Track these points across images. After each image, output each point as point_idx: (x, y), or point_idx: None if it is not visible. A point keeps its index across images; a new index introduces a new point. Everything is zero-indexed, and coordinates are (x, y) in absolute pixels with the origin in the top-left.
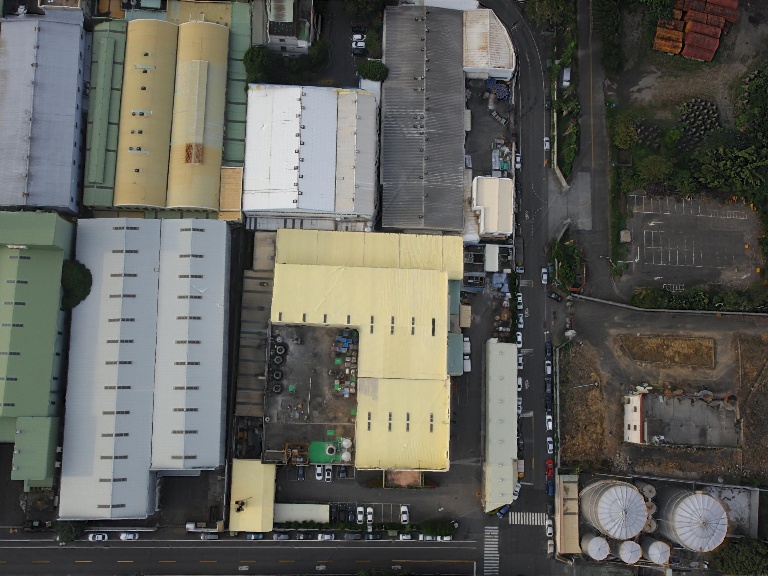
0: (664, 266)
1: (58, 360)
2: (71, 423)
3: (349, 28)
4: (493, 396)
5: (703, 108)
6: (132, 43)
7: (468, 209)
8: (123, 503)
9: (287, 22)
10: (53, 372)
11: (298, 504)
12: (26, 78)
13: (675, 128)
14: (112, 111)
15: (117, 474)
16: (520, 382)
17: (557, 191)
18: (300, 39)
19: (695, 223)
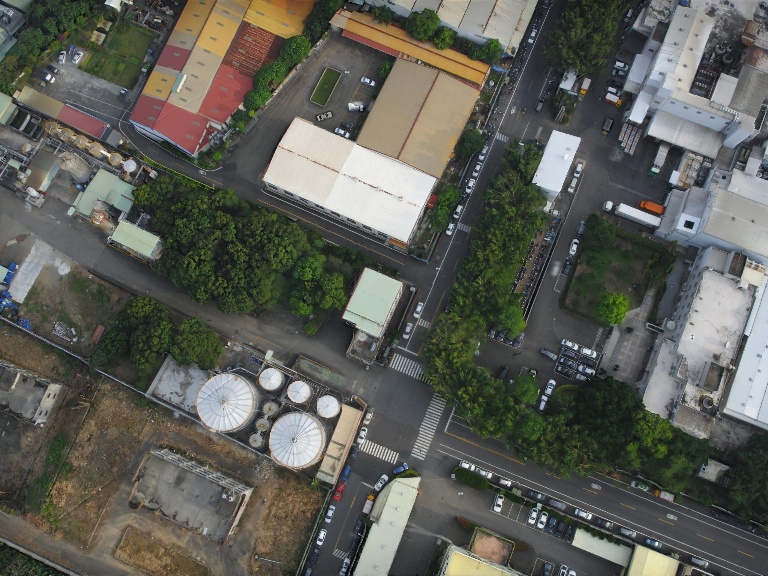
0: None
1: None
2: None
3: None
4: None
5: None
6: None
7: None
8: None
9: None
10: None
11: None
12: None
13: None
14: None
15: None
16: None
17: None
18: None
19: None
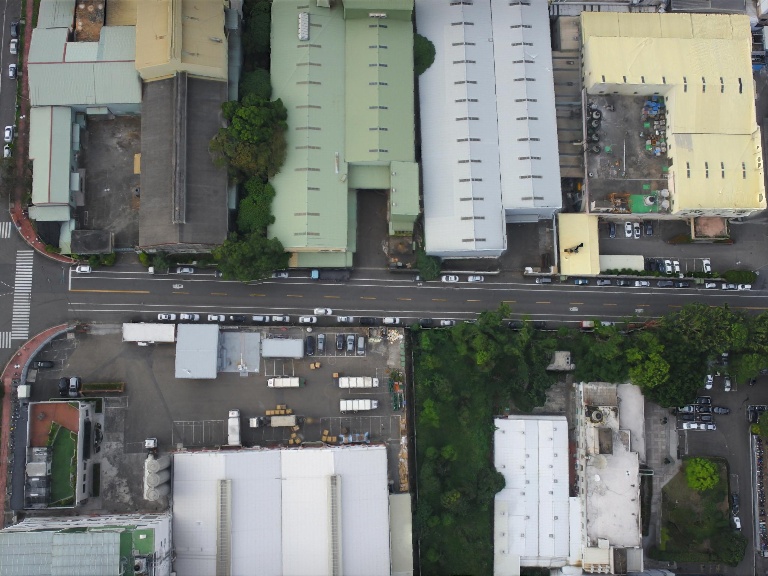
0: None
1: None
2: (429, 173)
3: None
4: None
5: None
6: None
7: None
8: (484, 238)
9: None
10: (414, 125)
11: (615, 255)
12: None
13: None
14: None
15: (476, 213)
16: None
17: None
18: None
19: None
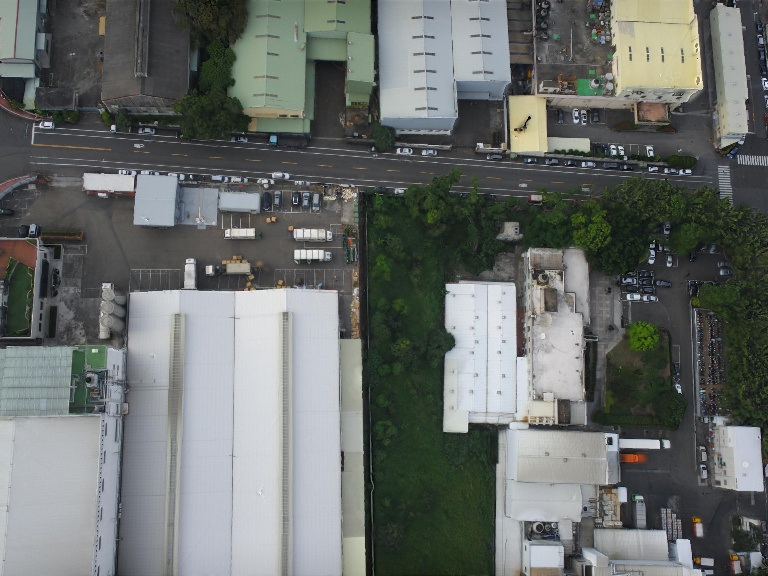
0: None
1: None
2: (384, 48)
3: None
4: (724, 48)
5: None
6: None
7: None
8: (436, 107)
9: None
10: None
11: (563, 138)
12: None
13: None
14: None
15: (429, 84)
16: None
17: None
18: None
19: None
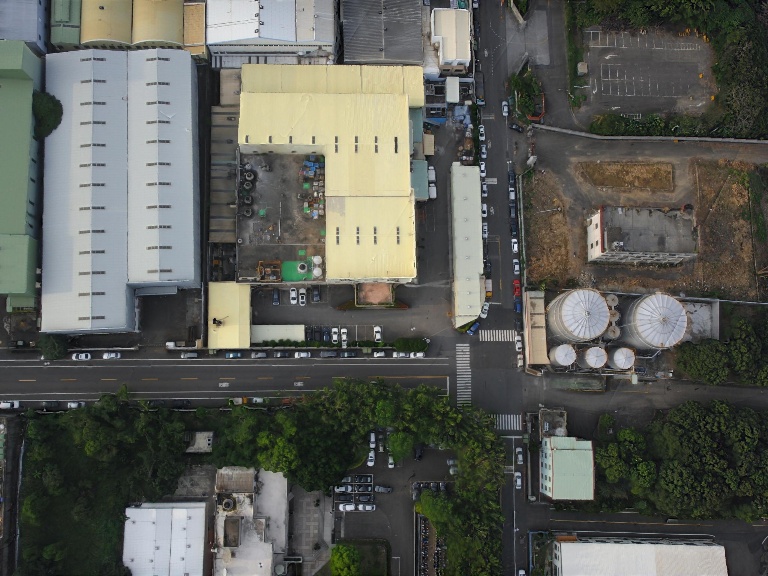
0: (621, 97)
1: (33, 186)
2: (49, 244)
3: None
4: (458, 215)
5: None
6: None
7: (427, 43)
8: (103, 315)
9: None
10: (29, 194)
11: (274, 325)
12: None
13: None
14: None
15: (95, 288)
16: (485, 208)
17: (515, 29)
18: None
19: (650, 55)
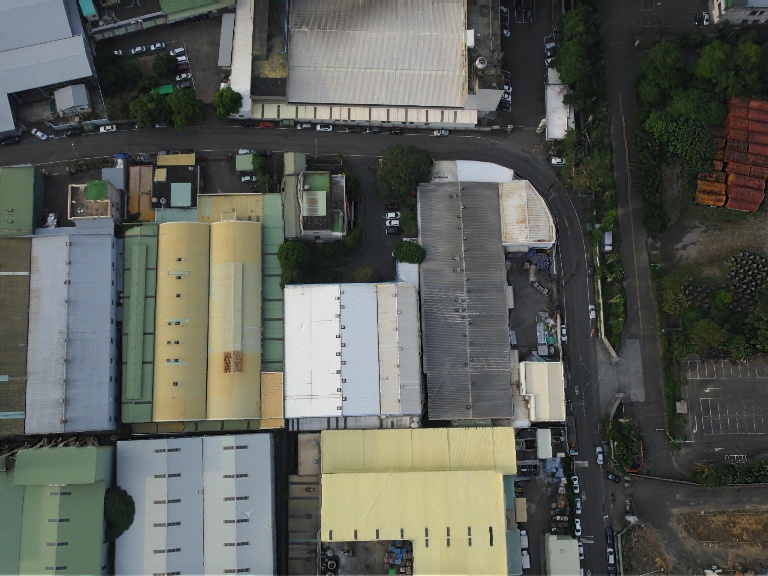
0: (724, 436)
1: None
2: None
3: (382, 206)
4: None
5: (752, 262)
6: (164, 247)
7: (516, 393)
8: None
9: (321, 216)
10: None
11: None
12: (59, 296)
13: (725, 286)
14: (147, 320)
15: None
16: (582, 574)
17: (606, 362)
18: (334, 231)
19: (753, 386)
